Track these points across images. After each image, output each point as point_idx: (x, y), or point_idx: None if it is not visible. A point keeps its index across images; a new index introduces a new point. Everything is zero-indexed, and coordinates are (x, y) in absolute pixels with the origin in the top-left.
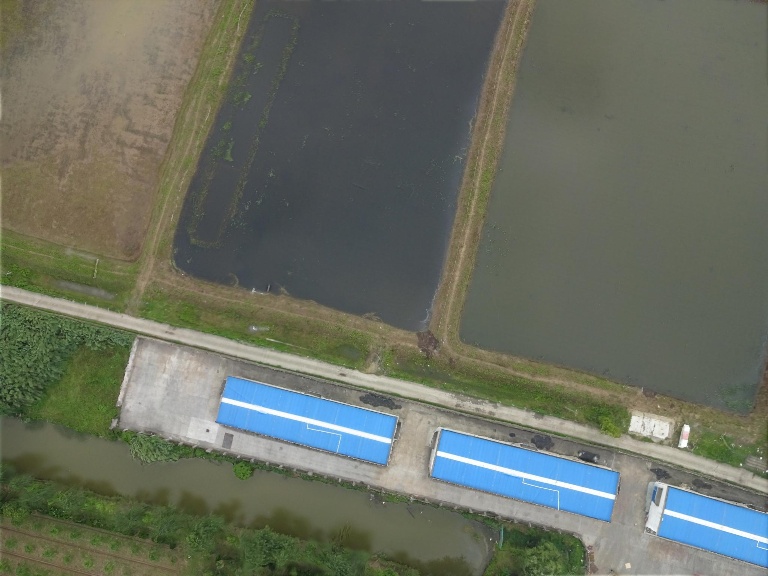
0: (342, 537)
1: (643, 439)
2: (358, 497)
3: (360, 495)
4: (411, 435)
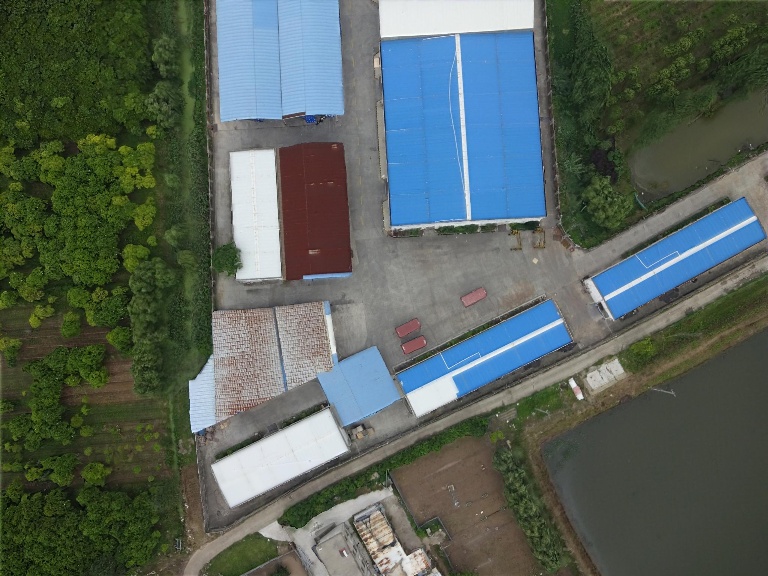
0: (766, 99)
1: (603, 361)
2: (761, 138)
3: (760, 141)
4: (767, 215)
